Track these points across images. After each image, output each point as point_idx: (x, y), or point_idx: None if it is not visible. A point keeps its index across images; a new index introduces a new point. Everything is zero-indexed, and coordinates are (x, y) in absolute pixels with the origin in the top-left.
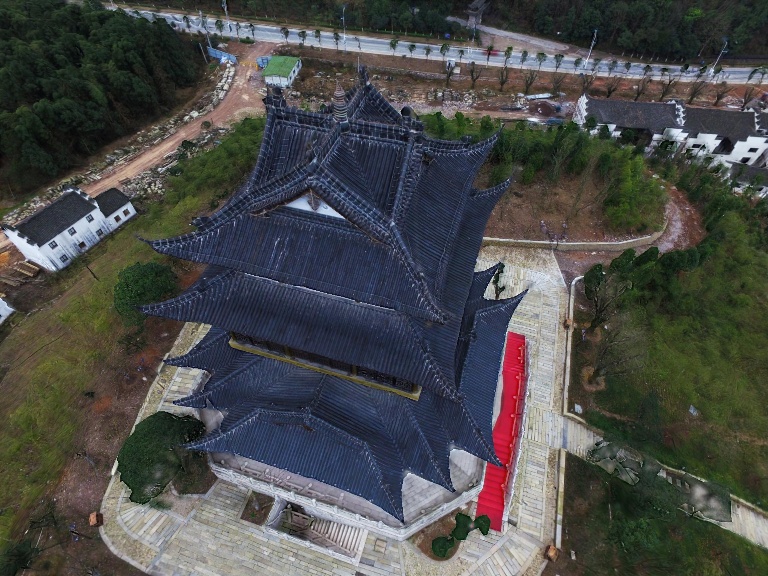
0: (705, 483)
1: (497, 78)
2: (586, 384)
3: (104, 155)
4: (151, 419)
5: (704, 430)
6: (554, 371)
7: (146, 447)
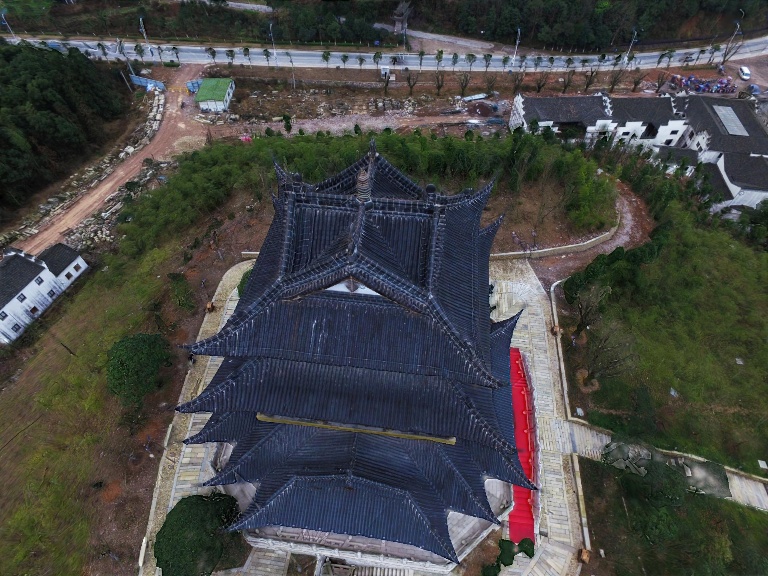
0: (703, 464)
1: (432, 82)
2: (582, 387)
3: (37, 205)
4: (184, 507)
5: (686, 409)
6: (551, 379)
7: (186, 538)
